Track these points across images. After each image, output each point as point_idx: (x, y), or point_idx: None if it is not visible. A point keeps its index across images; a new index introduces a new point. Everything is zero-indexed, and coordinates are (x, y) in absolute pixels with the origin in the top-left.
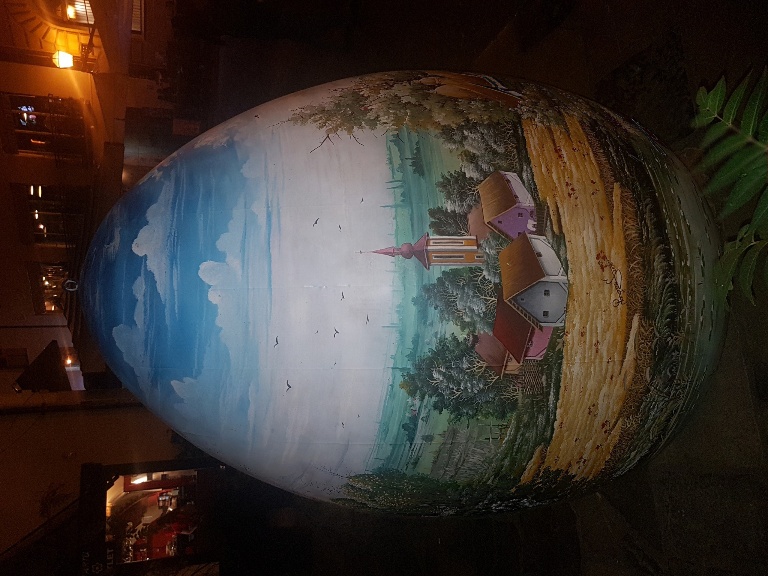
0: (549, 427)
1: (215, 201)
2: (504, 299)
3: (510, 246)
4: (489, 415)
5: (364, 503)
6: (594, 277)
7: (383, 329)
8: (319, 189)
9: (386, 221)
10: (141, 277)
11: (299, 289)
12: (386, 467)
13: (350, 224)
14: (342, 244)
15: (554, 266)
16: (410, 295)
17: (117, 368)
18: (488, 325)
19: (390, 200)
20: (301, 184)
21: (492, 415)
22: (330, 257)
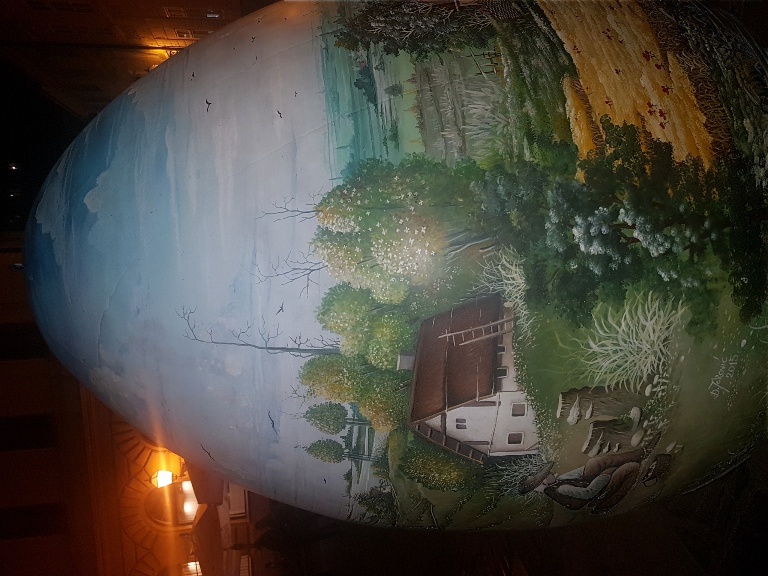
0: (560, 52)
1: None
2: None
3: None
4: (463, 45)
5: (366, 291)
6: None
7: (303, 17)
8: None
9: None
10: None
11: None
12: (358, 160)
13: None
14: None
15: None
16: None
17: (38, 271)
18: None
19: None
20: None
21: (467, 45)
22: None
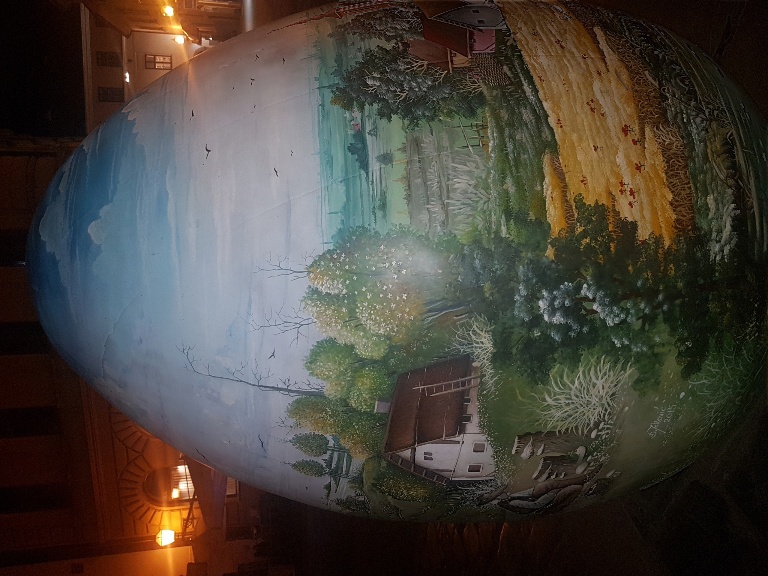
0: (544, 126)
1: None
2: (428, 18)
3: None
4: (453, 114)
5: (350, 346)
6: (527, 5)
7: (301, 62)
8: None
9: (297, 16)
10: None
11: None
12: (348, 226)
13: None
14: None
15: None
16: (325, 34)
17: (43, 285)
18: (416, 34)
19: None
20: None
21: (457, 114)
22: (244, 45)
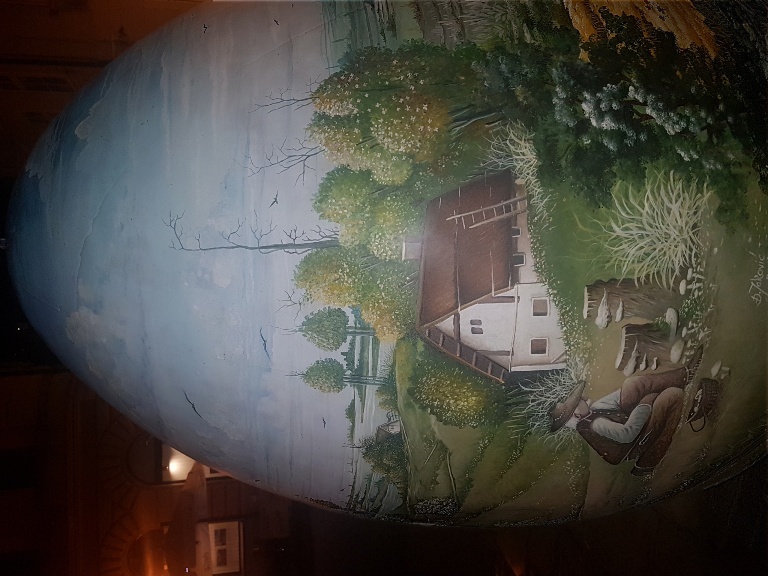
0: None
1: None
2: None
3: None
4: None
5: (366, 173)
6: None
7: None
8: None
9: None
10: None
11: None
12: (355, 49)
13: None
14: None
15: None
16: None
17: (21, 218)
18: None
19: None
20: None
21: None
22: None
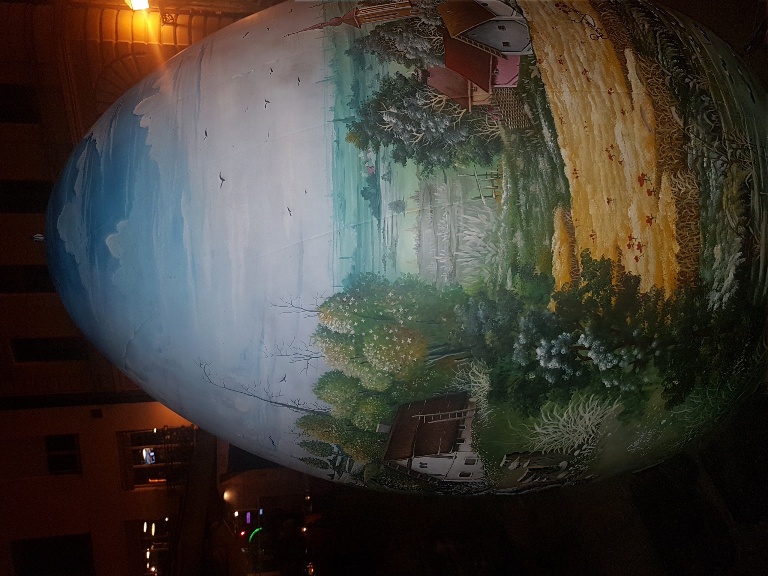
0: (559, 176)
1: (158, 70)
2: (451, 36)
3: (448, 2)
4: (469, 160)
5: (356, 379)
6: (557, 17)
7: (317, 85)
8: (251, 22)
9: (314, 13)
10: (85, 150)
11: (227, 82)
12: (358, 272)
13: (278, 24)
14: (270, 38)
15: (504, 10)
16: (342, 50)
17: (64, 280)
18: (438, 59)
19: (318, 3)
20: (236, 27)
21: (473, 160)
22: (258, 49)
